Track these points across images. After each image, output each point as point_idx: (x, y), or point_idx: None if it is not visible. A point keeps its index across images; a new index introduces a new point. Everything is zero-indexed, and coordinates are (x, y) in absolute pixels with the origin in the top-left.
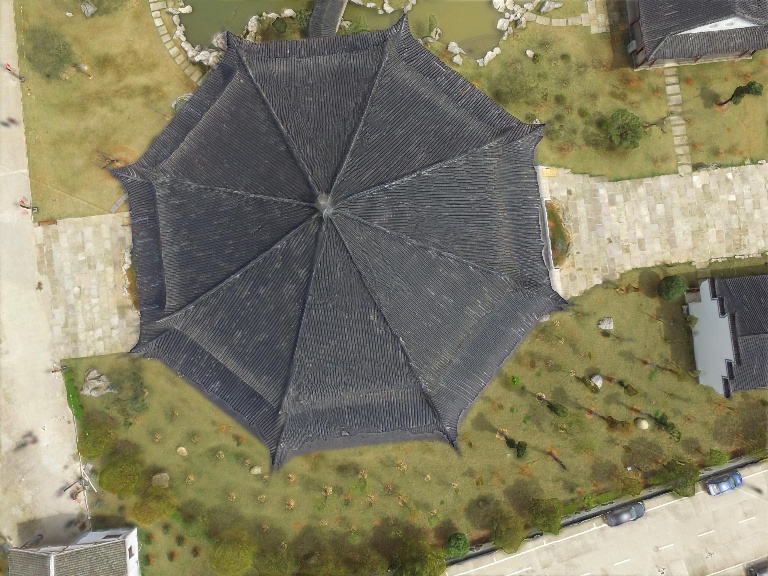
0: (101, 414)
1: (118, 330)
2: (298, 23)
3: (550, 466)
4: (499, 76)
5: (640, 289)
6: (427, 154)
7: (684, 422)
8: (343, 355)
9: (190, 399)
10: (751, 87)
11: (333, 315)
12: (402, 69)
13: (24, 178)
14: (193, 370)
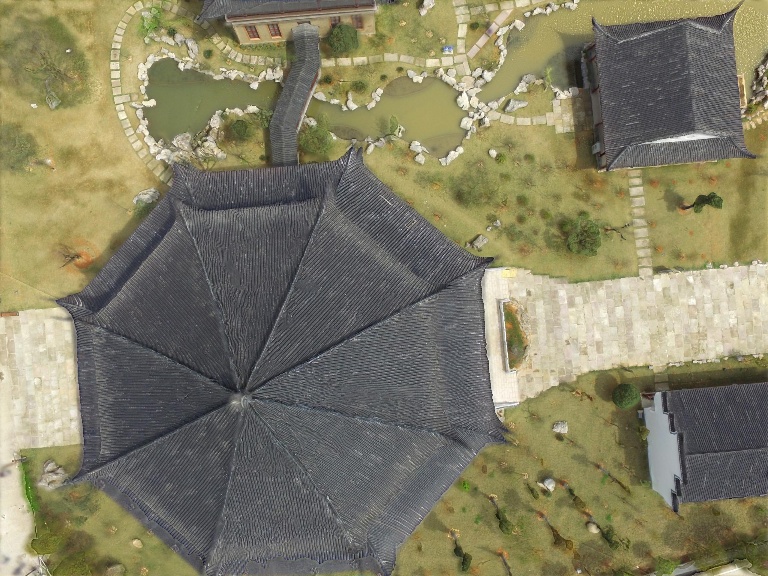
0: (59, 504)
1: (77, 422)
2: None
3: (501, 567)
4: (461, 176)
5: (596, 392)
6: (357, 318)
7: (636, 526)
8: (271, 512)
9: None
10: (711, 200)
11: (259, 479)
12: (339, 222)
13: None
14: (134, 499)
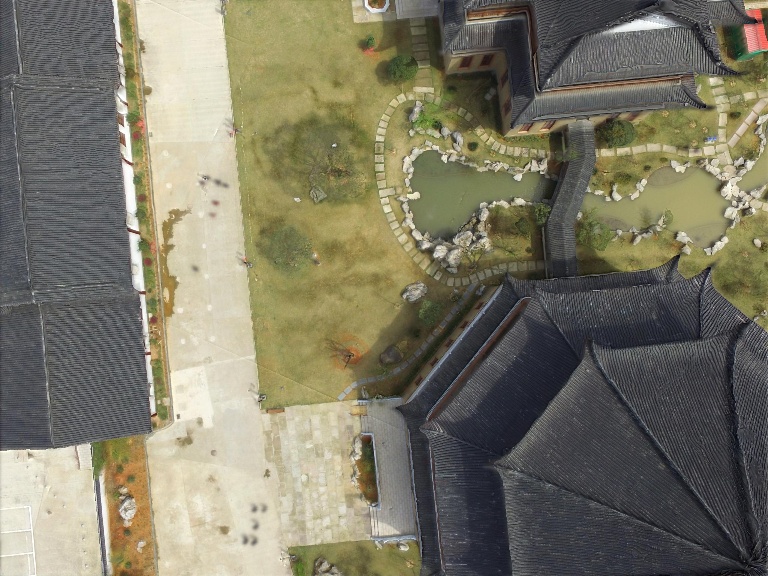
0: None
1: (346, 519)
2: (526, 210)
3: None
4: (726, 265)
5: None
6: None
7: None
8: None
9: None
10: None
11: None
12: (747, 359)
13: (251, 364)
14: None
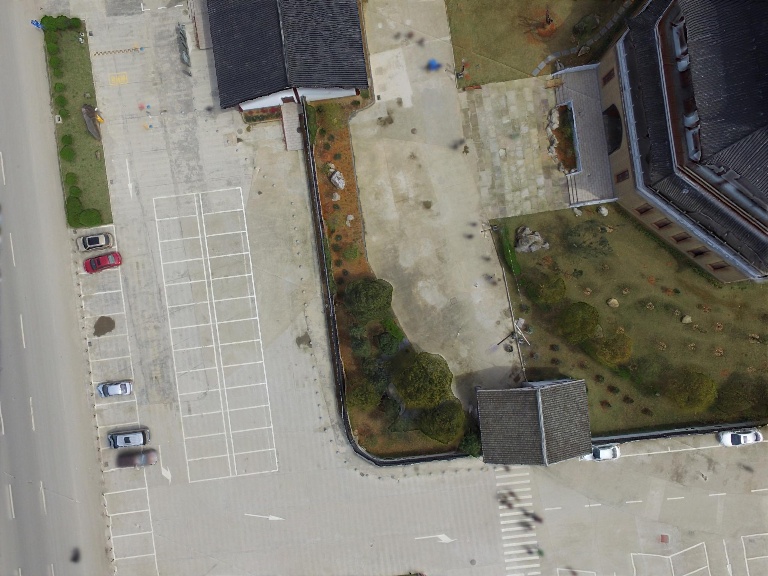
0: (532, 270)
1: (544, 189)
2: None
3: None
4: None
5: None
6: None
7: None
8: None
9: (619, 253)
10: None
11: None
12: None
13: (447, 45)
14: (757, 180)
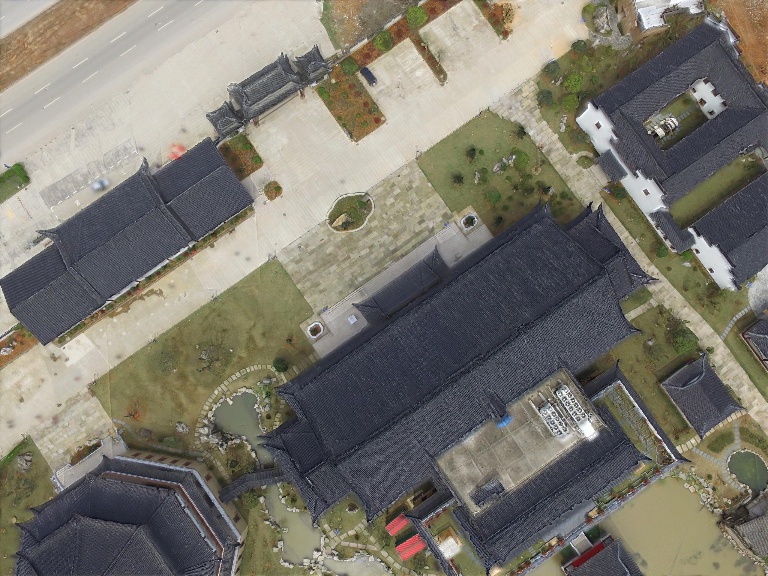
0: (13, 470)
1: (57, 455)
2: (253, 460)
3: None
4: (280, 574)
5: None
6: None
7: None
8: None
9: None
10: None
11: None
12: None
13: (108, 368)
14: None
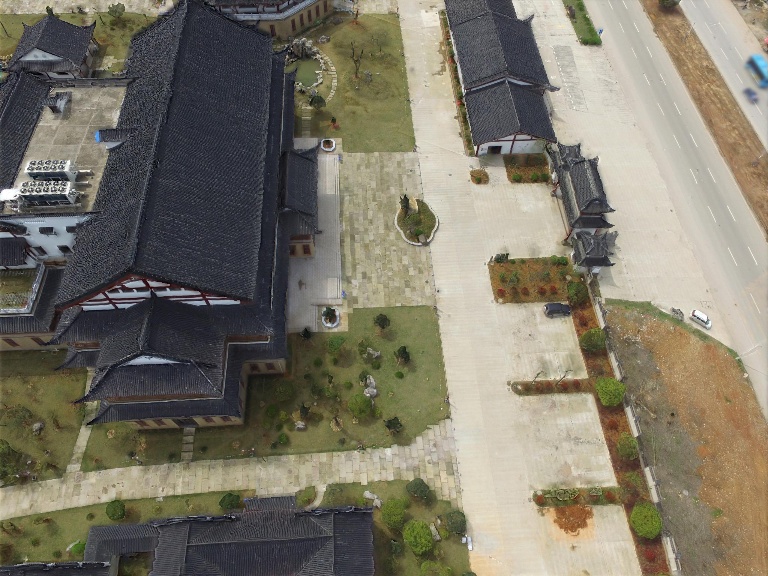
0: None
1: None
2: None
3: None
4: None
5: None
6: None
7: None
8: None
9: None
10: None
11: None
12: None
13: None
14: None
